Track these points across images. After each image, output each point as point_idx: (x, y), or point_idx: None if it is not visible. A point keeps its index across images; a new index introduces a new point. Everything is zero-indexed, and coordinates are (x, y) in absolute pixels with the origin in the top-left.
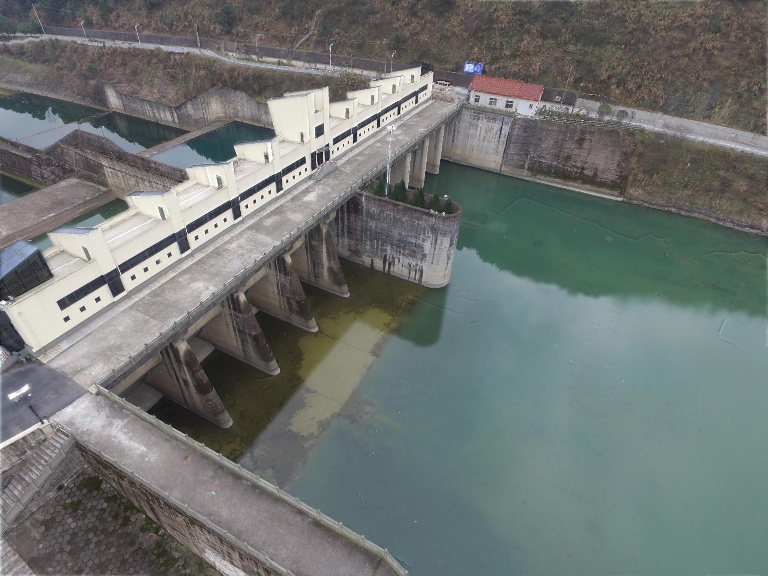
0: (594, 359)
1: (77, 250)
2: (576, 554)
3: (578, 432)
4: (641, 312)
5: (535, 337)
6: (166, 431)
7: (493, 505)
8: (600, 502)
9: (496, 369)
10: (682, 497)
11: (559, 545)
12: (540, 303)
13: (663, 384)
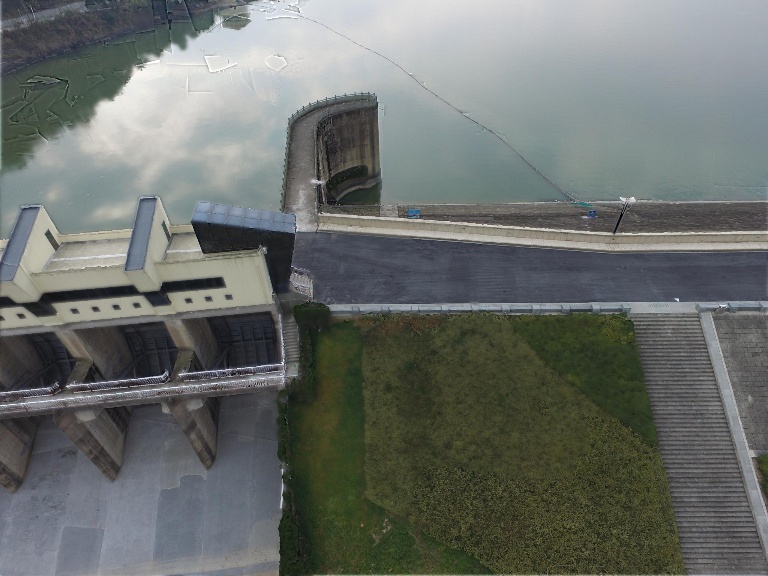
0: (82, 188)
1: (161, 243)
2: (233, 173)
3: (155, 184)
4: (15, 179)
5: (63, 212)
6: (285, 189)
7: (223, 195)
8: (200, 172)
9: (109, 219)
10: (184, 155)
11: (232, 176)
12: (10, 219)
13: (100, 165)
